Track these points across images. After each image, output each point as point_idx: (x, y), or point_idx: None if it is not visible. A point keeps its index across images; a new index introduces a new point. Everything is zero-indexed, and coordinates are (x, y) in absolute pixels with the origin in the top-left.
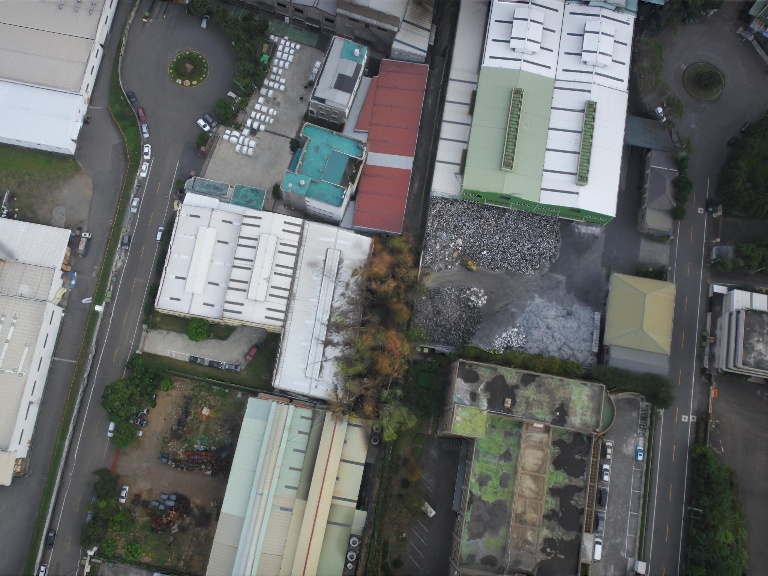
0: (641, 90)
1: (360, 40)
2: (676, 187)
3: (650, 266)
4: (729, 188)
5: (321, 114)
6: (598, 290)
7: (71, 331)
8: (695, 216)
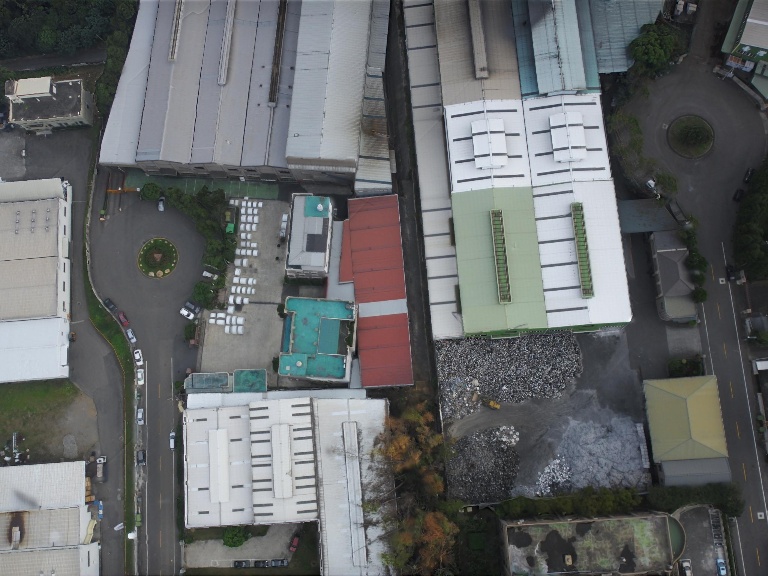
0: (626, 172)
1: (321, 182)
2: (690, 269)
3: (683, 357)
4: (747, 256)
5: (301, 276)
6: (634, 396)
7: (111, 563)
8: (718, 290)
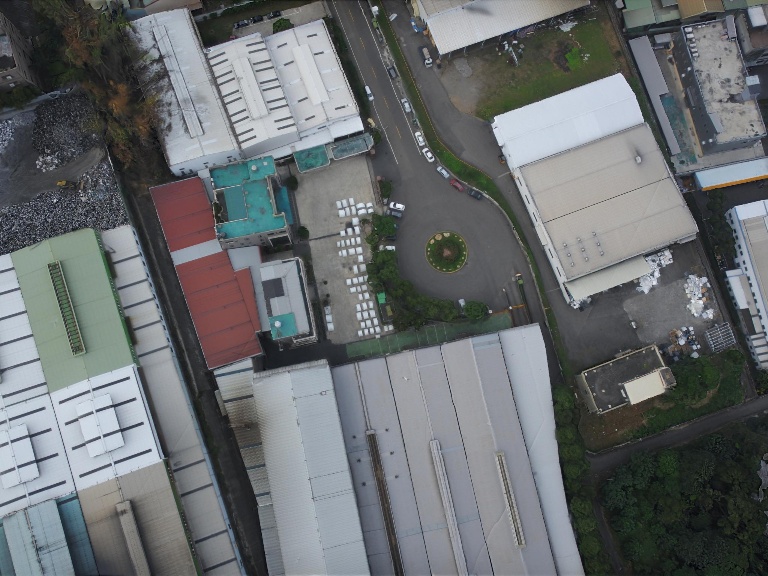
0: None
1: None
2: None
3: None
4: None
5: None
6: None
7: None
8: None
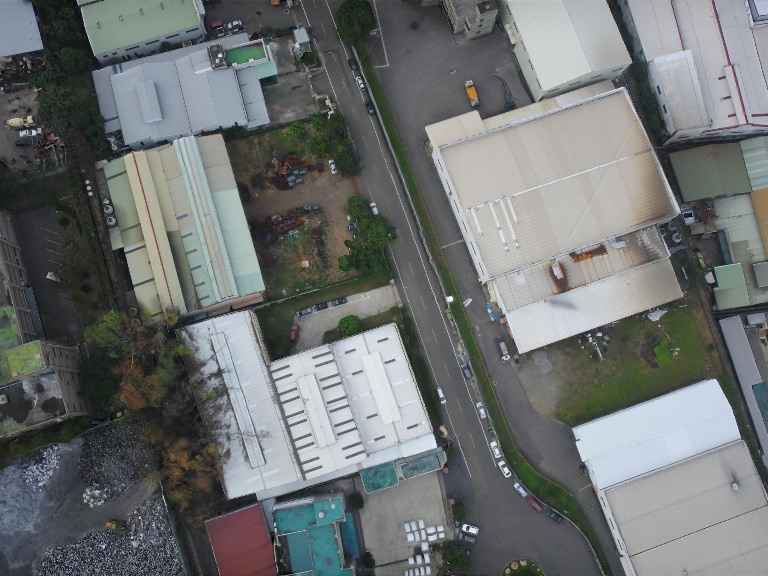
0: None
1: None
2: None
3: None
4: None
5: None
6: None
7: (464, 270)
8: None
